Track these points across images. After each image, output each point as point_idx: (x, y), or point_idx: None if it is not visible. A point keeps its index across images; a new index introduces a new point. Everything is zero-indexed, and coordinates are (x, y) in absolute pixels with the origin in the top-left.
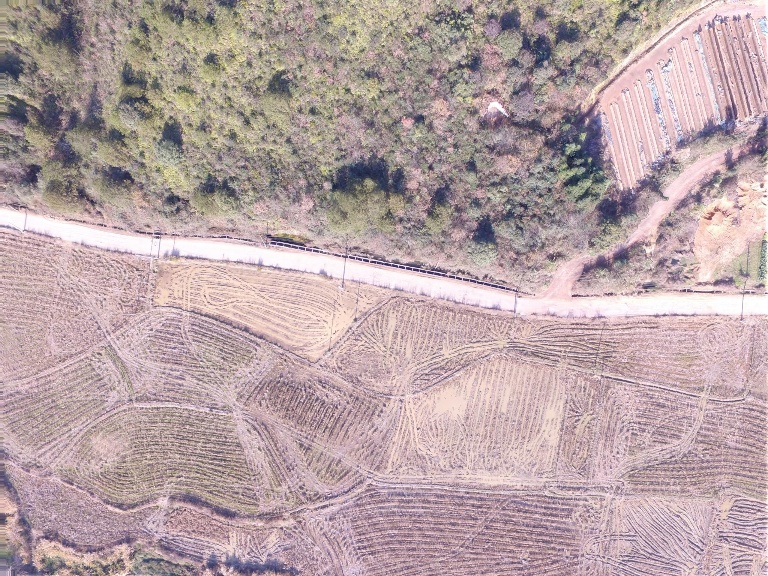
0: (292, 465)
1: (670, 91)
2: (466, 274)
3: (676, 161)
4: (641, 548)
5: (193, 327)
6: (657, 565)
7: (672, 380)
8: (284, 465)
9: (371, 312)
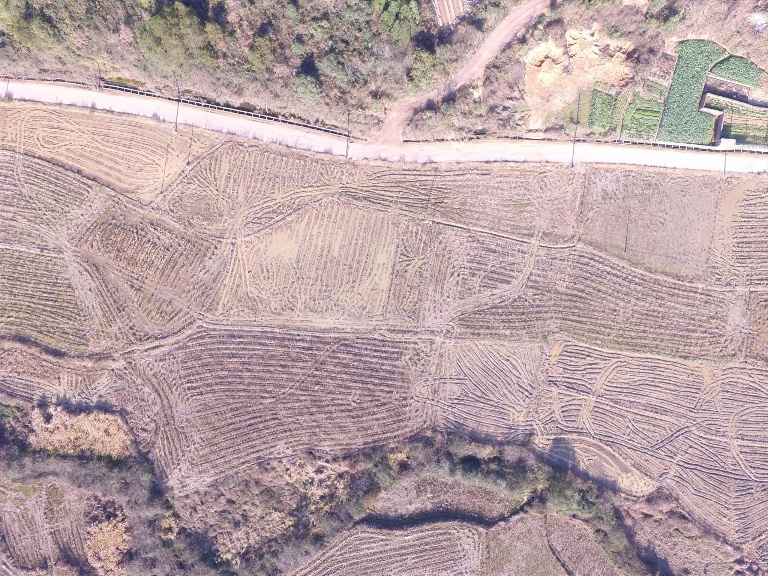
0: (123, 306)
1: None
2: (298, 118)
3: None
4: (470, 391)
5: (26, 169)
6: (486, 408)
7: (503, 226)
8: (115, 306)
9: (204, 156)
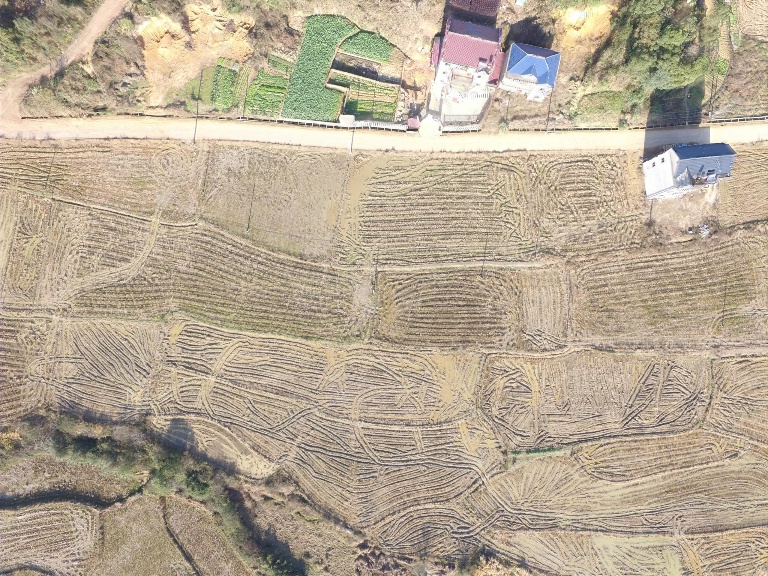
0: None
1: None
2: None
3: None
4: (86, 371)
5: None
6: (102, 388)
7: (123, 204)
8: None
9: None
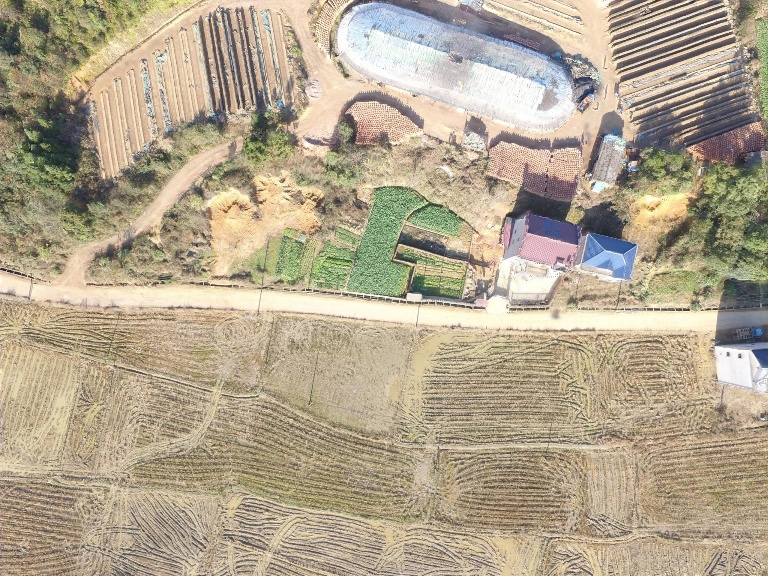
0: None
1: (162, 81)
2: None
3: (166, 151)
4: (143, 542)
5: None
6: (158, 560)
7: (184, 373)
8: None
9: None
